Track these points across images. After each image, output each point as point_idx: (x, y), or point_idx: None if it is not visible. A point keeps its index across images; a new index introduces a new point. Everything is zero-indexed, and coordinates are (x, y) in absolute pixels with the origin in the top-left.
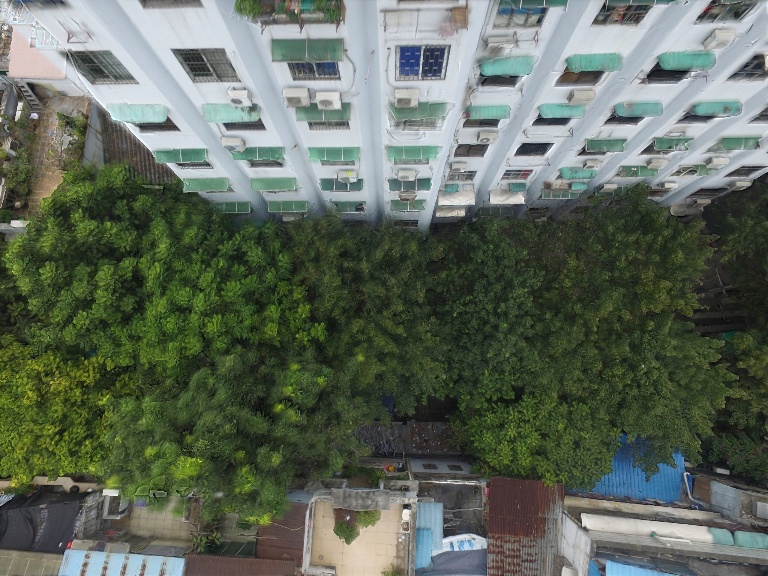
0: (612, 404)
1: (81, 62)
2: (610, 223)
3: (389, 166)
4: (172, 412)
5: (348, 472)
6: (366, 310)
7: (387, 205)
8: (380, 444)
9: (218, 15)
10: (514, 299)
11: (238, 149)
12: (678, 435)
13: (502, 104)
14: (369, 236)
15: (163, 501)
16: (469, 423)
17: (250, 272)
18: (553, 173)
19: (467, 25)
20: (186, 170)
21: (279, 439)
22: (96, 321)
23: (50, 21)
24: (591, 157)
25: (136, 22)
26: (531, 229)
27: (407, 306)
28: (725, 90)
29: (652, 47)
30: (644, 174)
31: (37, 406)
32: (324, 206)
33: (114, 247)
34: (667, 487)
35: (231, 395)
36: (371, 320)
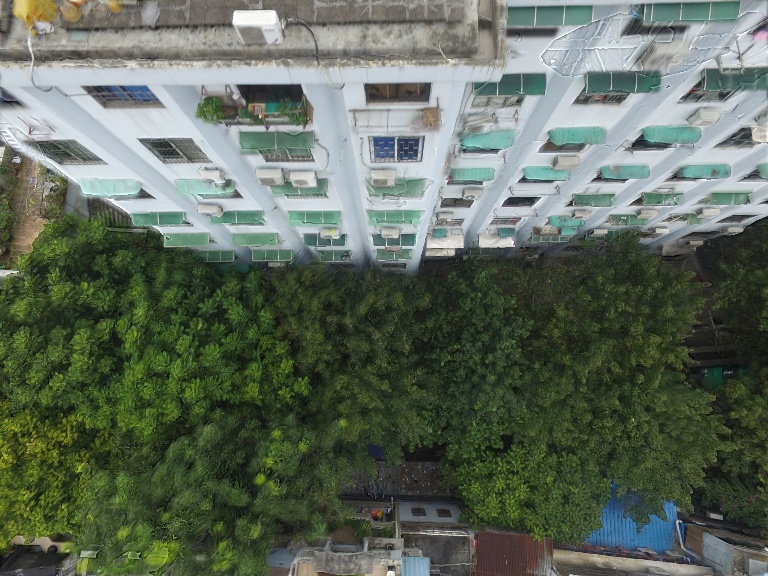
0: (602, 454)
1: (45, 149)
2: (599, 272)
3: (372, 224)
4: (146, 488)
5: (333, 525)
6: (350, 364)
7: (373, 252)
8: (369, 485)
9: (182, 113)
10: (502, 350)
11: (215, 215)
12: (669, 490)
13: (486, 166)
14: (354, 287)
15: (143, 559)
16: (458, 470)
17: (231, 330)
18: (542, 220)
19: (441, 118)
20: (166, 227)
21: (257, 509)
22: (73, 382)
23: (10, 115)
24: (580, 208)
25: (98, 118)
26: (520, 275)
27: (393, 357)
28: (713, 155)
29: (636, 121)
30: (634, 223)
31: (12, 469)
32: (310, 252)
33: (92, 306)
34: (659, 535)
35: (207, 467)
36: (355, 375)
